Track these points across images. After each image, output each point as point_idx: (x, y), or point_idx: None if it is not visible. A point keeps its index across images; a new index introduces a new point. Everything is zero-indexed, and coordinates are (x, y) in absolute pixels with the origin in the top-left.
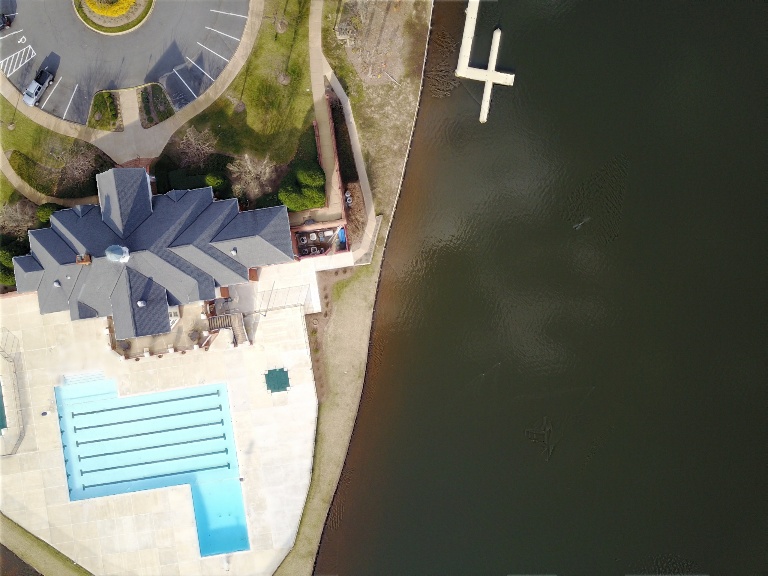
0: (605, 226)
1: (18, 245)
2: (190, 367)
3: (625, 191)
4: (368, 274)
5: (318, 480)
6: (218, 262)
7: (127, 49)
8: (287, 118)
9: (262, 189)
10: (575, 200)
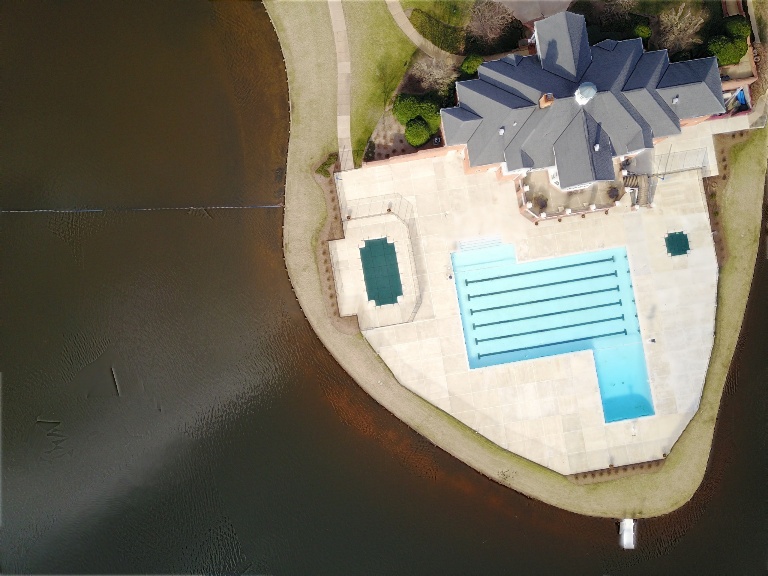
0: None
1: None
2: (589, 231)
3: None
4: (761, 138)
5: (719, 344)
6: (662, 109)
7: None
8: None
9: None
10: None
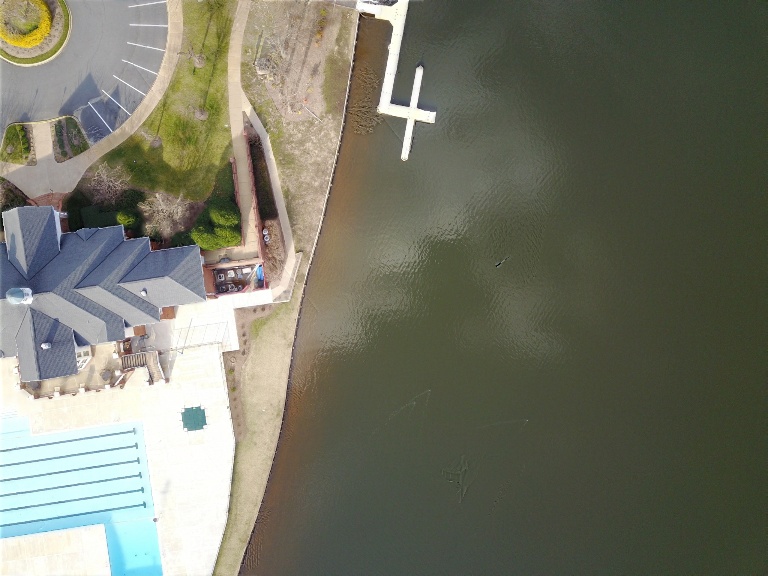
0: (524, 265)
1: None
2: (105, 405)
3: (545, 230)
4: (287, 311)
5: (235, 519)
6: (127, 303)
7: (41, 81)
8: (204, 154)
9: (175, 227)
10: (498, 237)
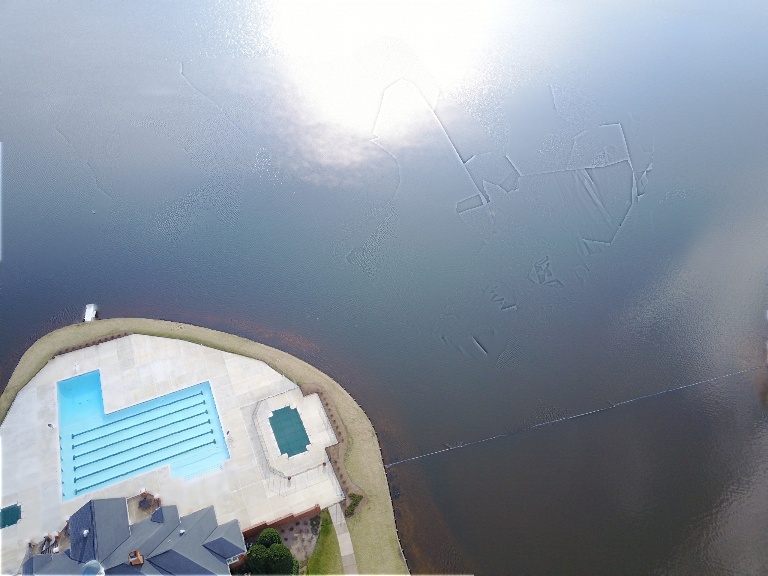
0: None
1: (255, 571)
2: None
3: None
4: None
5: None
6: None
7: None
8: None
9: None
10: None
